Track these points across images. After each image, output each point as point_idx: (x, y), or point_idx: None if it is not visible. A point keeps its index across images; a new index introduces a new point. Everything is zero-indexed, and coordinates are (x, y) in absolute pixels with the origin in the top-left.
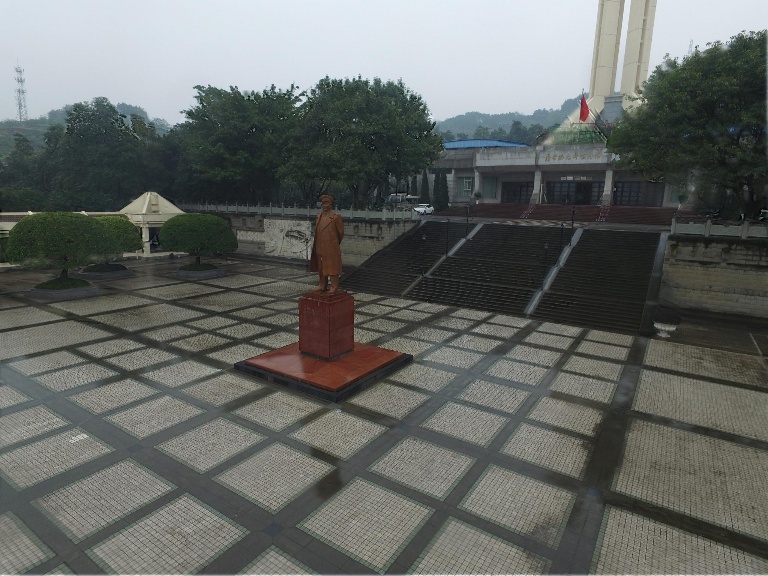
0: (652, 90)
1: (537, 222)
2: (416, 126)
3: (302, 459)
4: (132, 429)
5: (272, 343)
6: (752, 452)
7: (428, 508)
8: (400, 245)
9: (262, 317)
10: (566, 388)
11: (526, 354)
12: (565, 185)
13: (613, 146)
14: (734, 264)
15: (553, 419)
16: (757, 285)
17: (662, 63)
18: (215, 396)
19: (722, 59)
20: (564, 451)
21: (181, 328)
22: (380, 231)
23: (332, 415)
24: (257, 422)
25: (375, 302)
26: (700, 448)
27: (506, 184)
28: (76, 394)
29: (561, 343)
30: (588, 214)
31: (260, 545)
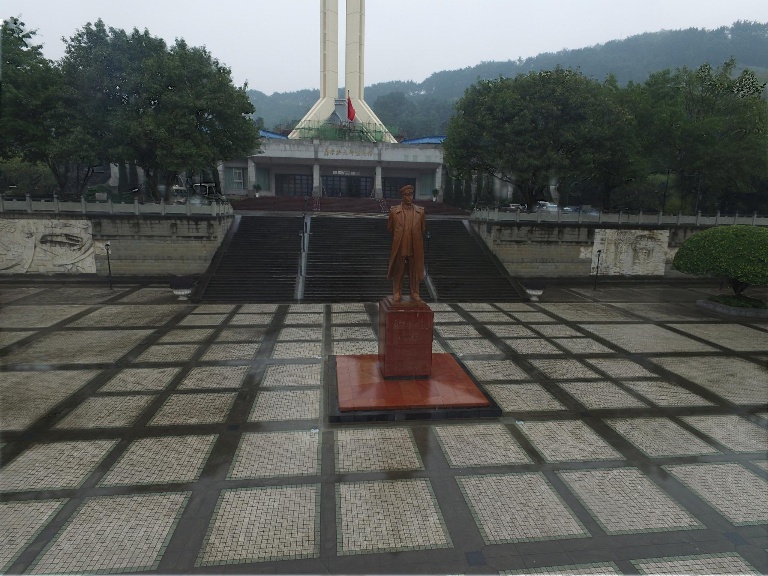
0: (479, 104)
1: (345, 214)
2: (248, 106)
3: (606, 475)
4: (413, 542)
5: (293, 381)
6: (712, 359)
7: (733, 463)
8: (234, 244)
9: (198, 355)
10: (580, 349)
11: (506, 331)
12: (337, 179)
13: (453, 147)
14: (535, 241)
15: (624, 373)
16: (548, 255)
17: (476, 82)
18: (392, 459)
19: (538, 89)
20: (675, 391)
21: (111, 399)
22: (212, 229)
23: (527, 428)
24: (497, 464)
25: (286, 311)
26: (699, 365)
27: (279, 176)
28: (201, 551)
29: (503, 317)
30: (371, 206)
31: (764, 556)
